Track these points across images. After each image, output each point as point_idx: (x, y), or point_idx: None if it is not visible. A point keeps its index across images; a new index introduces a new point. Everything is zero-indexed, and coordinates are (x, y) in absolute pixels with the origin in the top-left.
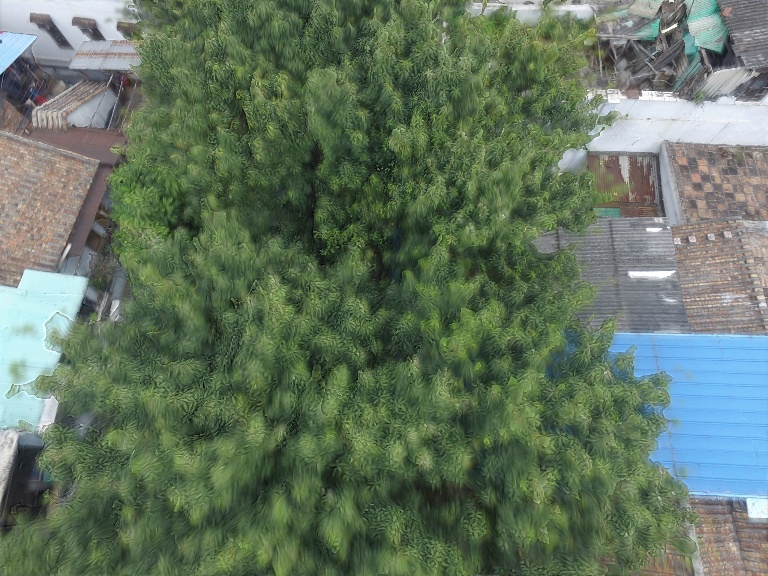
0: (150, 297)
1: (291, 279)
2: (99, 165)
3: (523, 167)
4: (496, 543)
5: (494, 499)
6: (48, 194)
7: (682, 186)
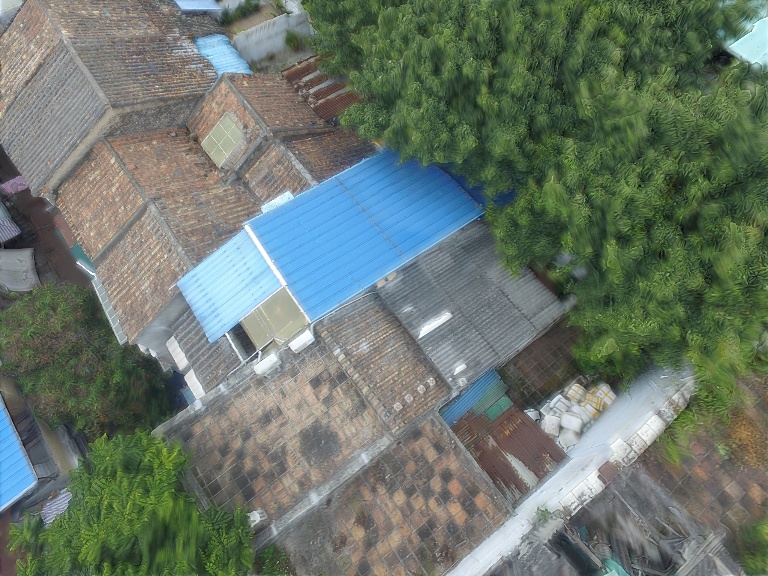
0: None
1: (672, 27)
2: None
3: (639, 129)
4: None
5: None
6: None
7: (462, 463)
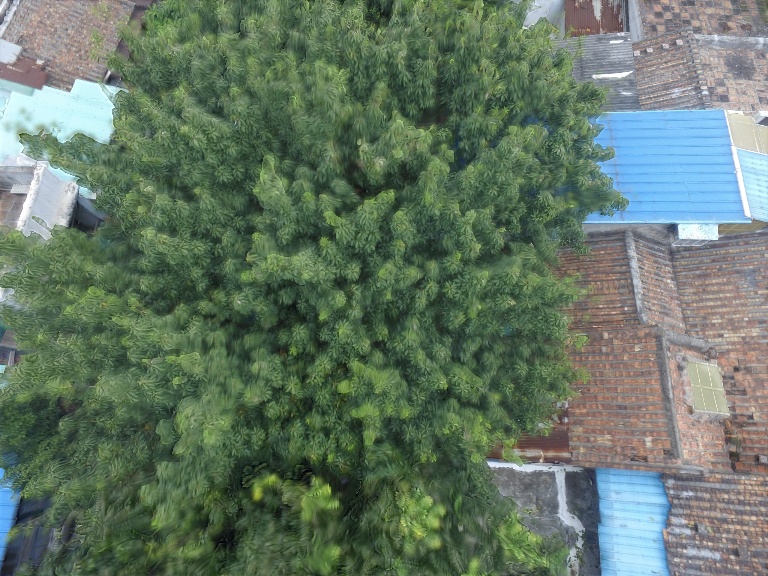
0: (196, 1)
1: None
2: (135, 7)
3: None
4: (459, 147)
5: (459, 120)
6: (92, 25)
7: (645, 14)
